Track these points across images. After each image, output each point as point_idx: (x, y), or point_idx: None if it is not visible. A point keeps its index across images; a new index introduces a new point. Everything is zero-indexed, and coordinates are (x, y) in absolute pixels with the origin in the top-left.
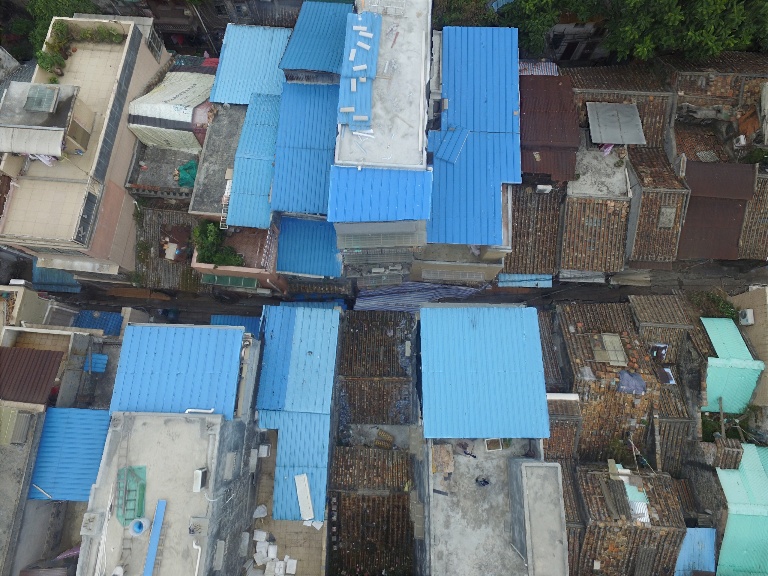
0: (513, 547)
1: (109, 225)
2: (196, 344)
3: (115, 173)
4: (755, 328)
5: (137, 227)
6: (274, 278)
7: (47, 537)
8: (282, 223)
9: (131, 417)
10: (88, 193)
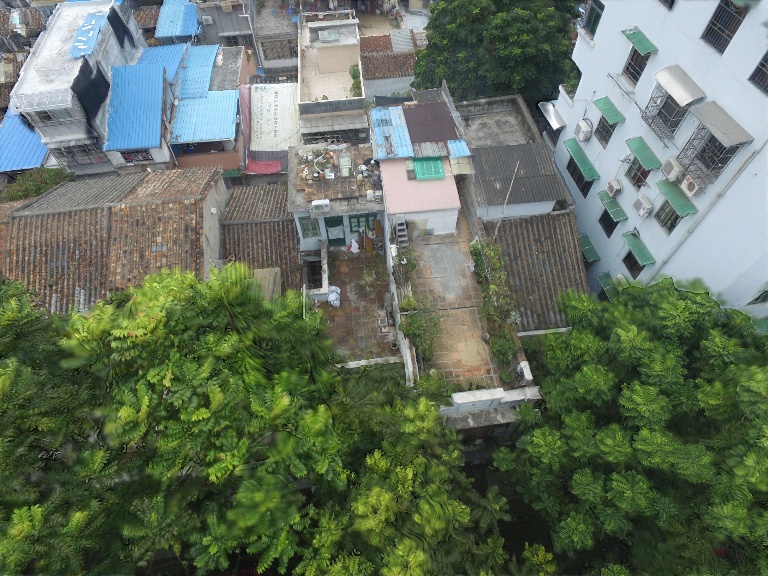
0: None
1: None
2: None
3: None
4: None
5: None
6: None
7: None
8: None
9: None
10: None
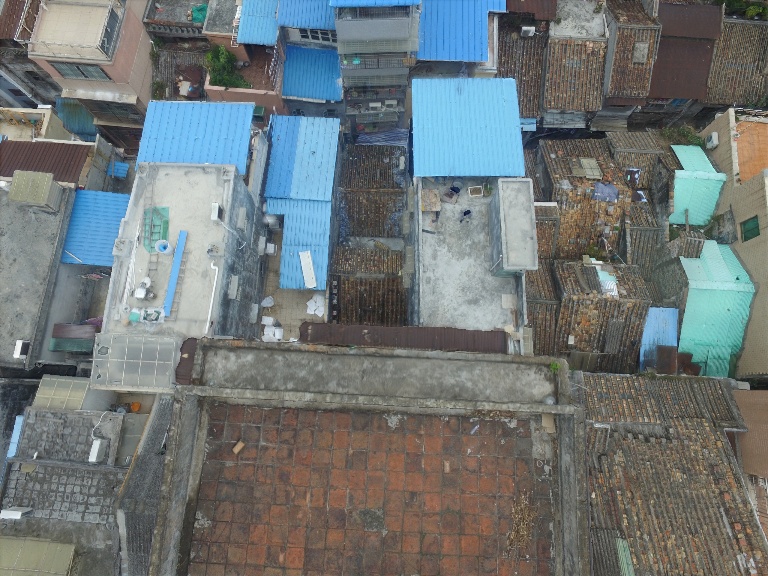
0: (492, 269)
1: (129, 51)
2: (212, 116)
3: (134, 4)
4: (719, 148)
5: (153, 68)
6: (280, 105)
7: (76, 309)
8: (287, 50)
9: (155, 168)
10: (111, 9)
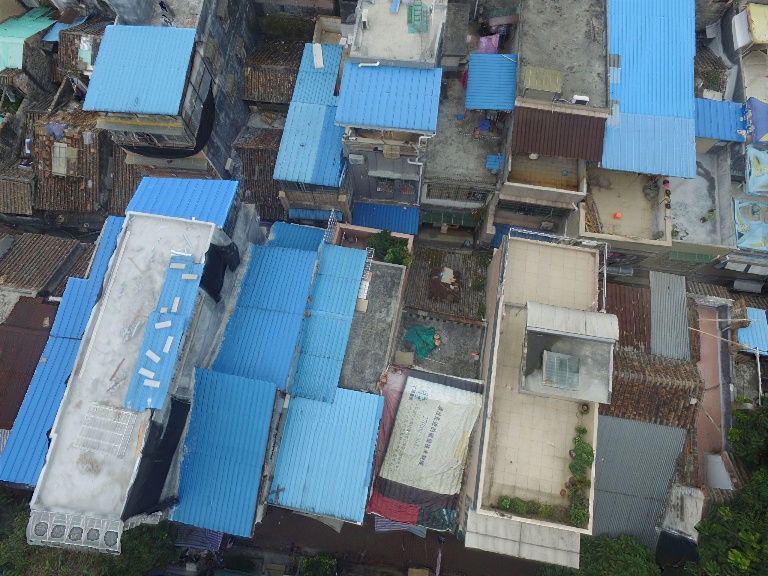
0: None
1: None
2: (375, 113)
3: None
4: None
5: None
6: None
7: None
8: None
9: None
10: None
